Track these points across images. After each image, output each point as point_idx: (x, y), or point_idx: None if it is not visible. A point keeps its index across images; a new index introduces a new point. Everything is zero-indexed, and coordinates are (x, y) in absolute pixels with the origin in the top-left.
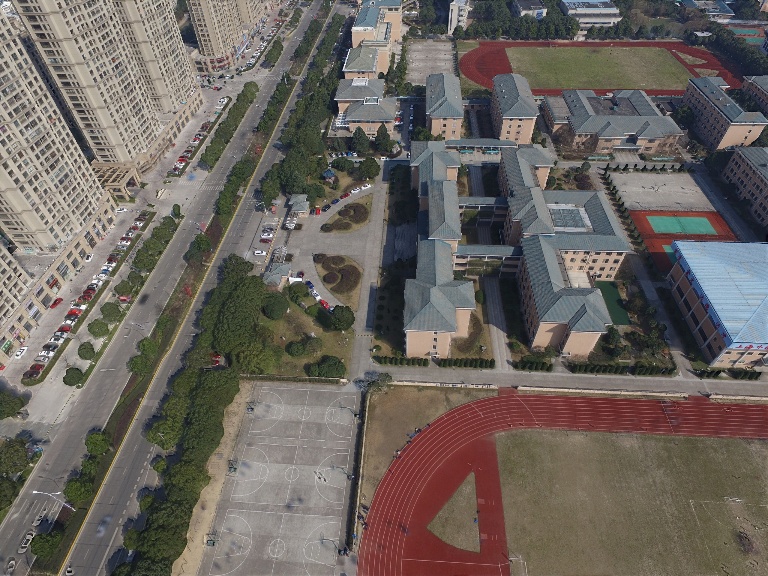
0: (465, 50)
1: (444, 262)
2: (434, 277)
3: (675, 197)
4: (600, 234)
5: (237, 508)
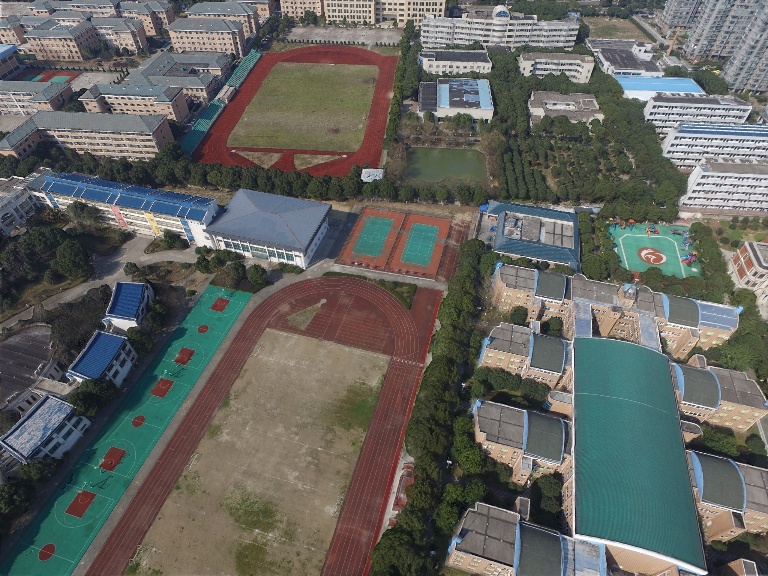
0: (374, 49)
1: (61, 4)
2: (52, 0)
3: (78, 88)
4: (38, 28)
5: (25, 6)
